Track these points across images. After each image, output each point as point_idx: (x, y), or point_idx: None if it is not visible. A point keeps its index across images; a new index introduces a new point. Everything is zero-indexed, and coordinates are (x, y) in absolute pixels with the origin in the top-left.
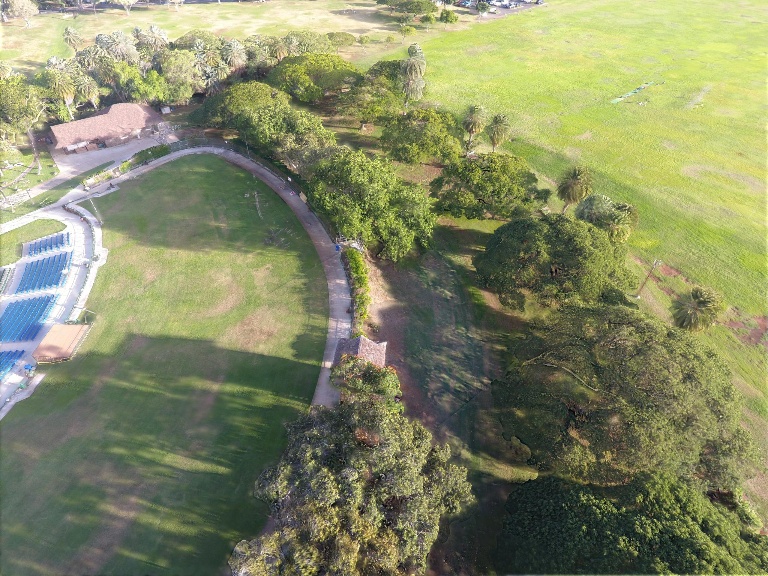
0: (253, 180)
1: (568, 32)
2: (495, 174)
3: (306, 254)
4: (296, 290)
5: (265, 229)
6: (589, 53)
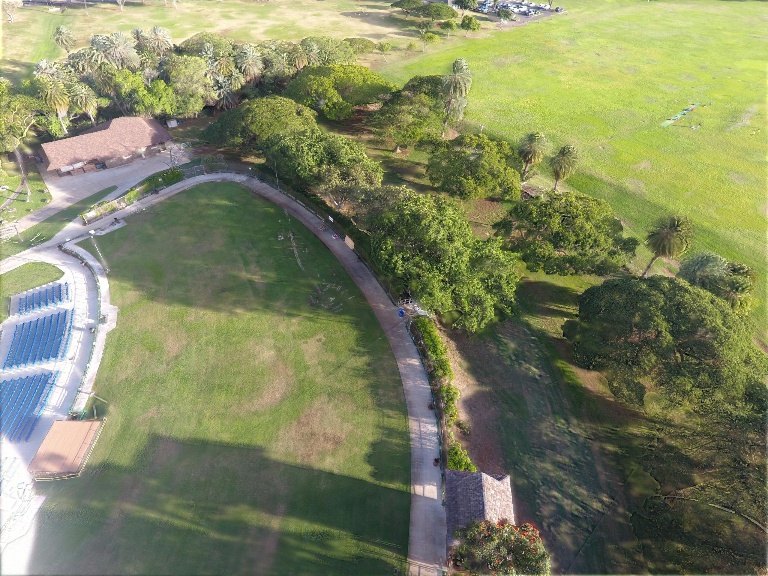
0: (286, 217)
1: (596, 44)
2: (578, 221)
3: (364, 321)
4: (360, 373)
5: (309, 284)
6: (623, 68)
